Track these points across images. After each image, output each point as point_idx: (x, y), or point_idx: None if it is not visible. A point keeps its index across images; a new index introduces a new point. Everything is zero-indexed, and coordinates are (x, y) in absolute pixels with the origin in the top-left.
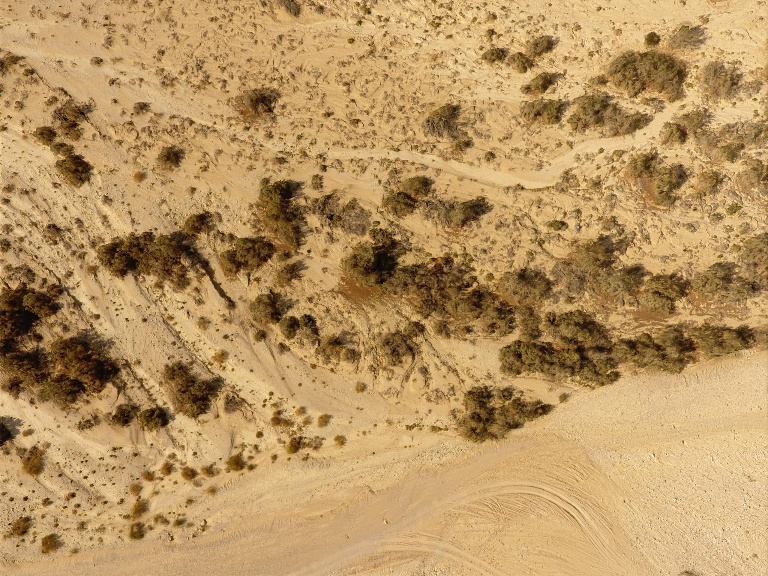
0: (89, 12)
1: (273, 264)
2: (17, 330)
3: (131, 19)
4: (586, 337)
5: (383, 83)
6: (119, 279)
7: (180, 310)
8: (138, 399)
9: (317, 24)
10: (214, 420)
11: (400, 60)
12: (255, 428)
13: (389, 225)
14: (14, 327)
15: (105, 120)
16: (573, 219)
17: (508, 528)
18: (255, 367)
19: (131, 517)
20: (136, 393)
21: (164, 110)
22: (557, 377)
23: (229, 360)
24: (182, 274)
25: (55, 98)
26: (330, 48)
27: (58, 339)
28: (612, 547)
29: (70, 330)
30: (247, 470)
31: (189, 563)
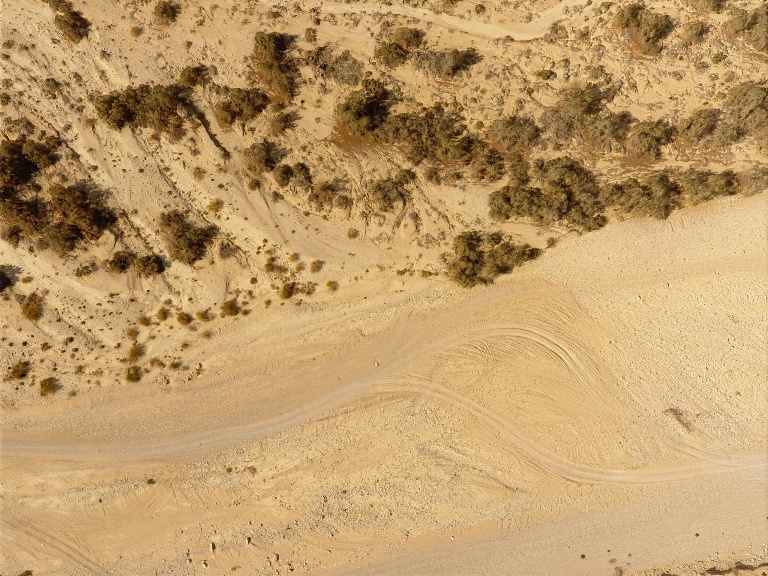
0: None
1: (267, 114)
2: (16, 178)
3: None
4: (573, 178)
5: None
6: (116, 131)
7: (176, 161)
8: (135, 247)
9: None
10: (209, 266)
11: None
12: (249, 274)
13: (381, 75)
14: (14, 175)
15: None
16: (561, 68)
17: (496, 369)
18: (249, 215)
19: (128, 361)
20: (133, 241)
21: None
22: (545, 219)
23: (224, 209)
24: (178, 124)
25: None
26: None
27: (57, 184)
28: (598, 386)
29: (68, 180)
30: (241, 315)
31: (184, 405)
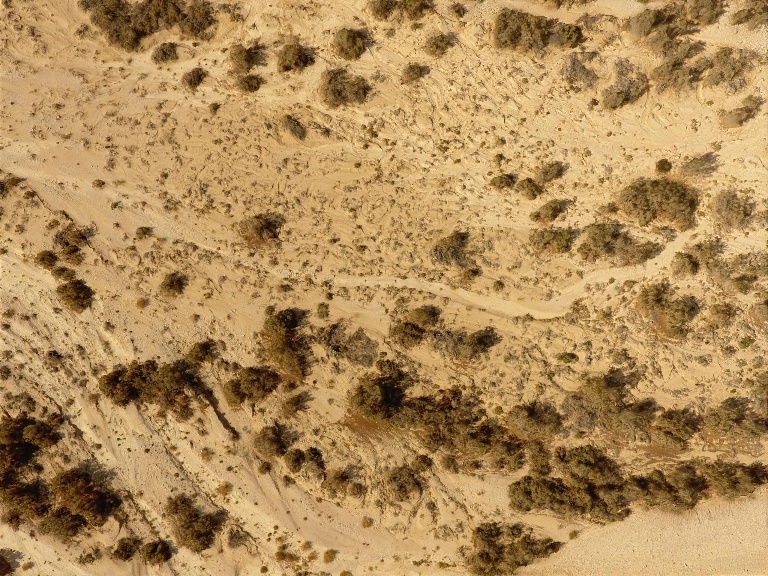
0: (91, 133)
1: (278, 395)
2: (17, 463)
3: (134, 141)
4: (597, 477)
5: (390, 209)
6: (121, 408)
7: (183, 440)
8: (140, 532)
9: (323, 147)
10: (218, 555)
11: (407, 185)
12: (259, 563)
13: (396, 356)
14: (14, 460)
15: (107, 245)
16: (583, 352)
17: None
18: (260, 500)
19: None
20: (138, 526)
21: (167, 235)
22: (567, 516)
23: (233, 492)
24: (185, 405)
25: (56, 222)
26: (336, 172)
27: (59, 474)
28: None
29: (71, 461)
30: None
31: None
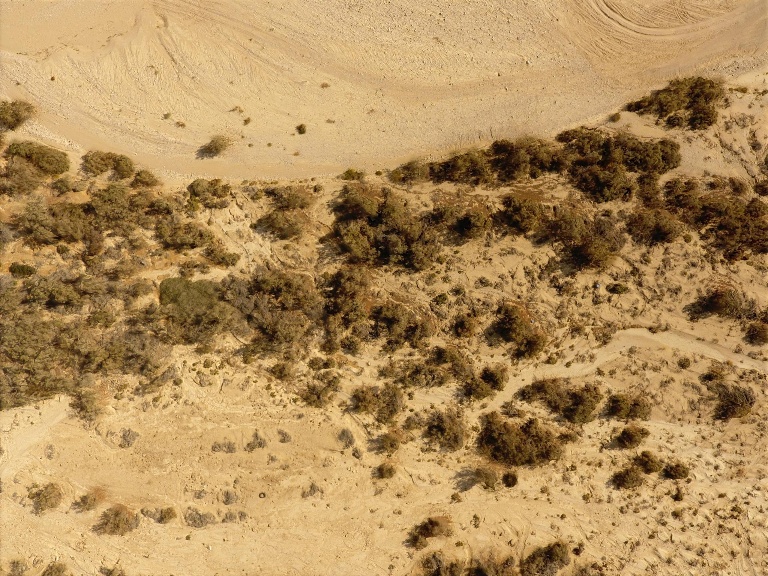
0: None
1: None
2: None
3: None
4: (603, 174)
5: None
6: None
7: None
8: None
9: None
10: None
11: None
12: None
13: None
14: None
15: None
16: (602, 295)
17: None
18: None
19: None
20: None
21: None
22: None
23: None
24: None
25: None
26: None
27: None
28: None
29: None
30: None
31: None
